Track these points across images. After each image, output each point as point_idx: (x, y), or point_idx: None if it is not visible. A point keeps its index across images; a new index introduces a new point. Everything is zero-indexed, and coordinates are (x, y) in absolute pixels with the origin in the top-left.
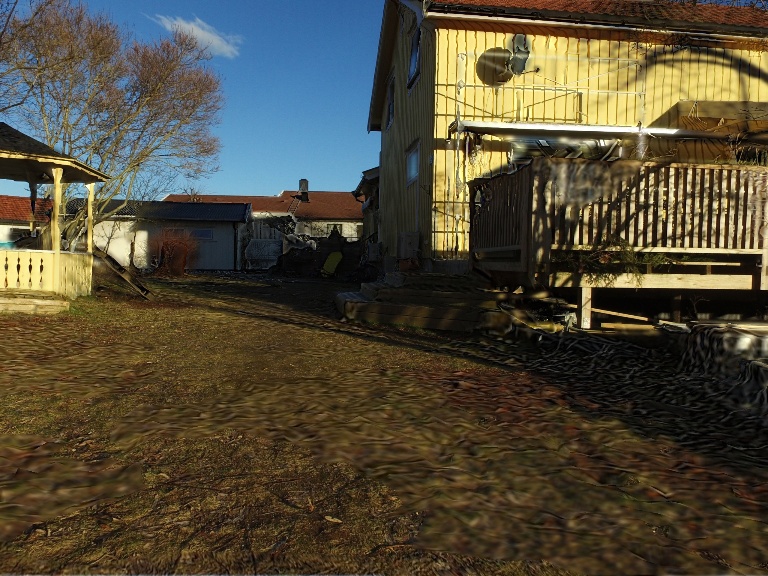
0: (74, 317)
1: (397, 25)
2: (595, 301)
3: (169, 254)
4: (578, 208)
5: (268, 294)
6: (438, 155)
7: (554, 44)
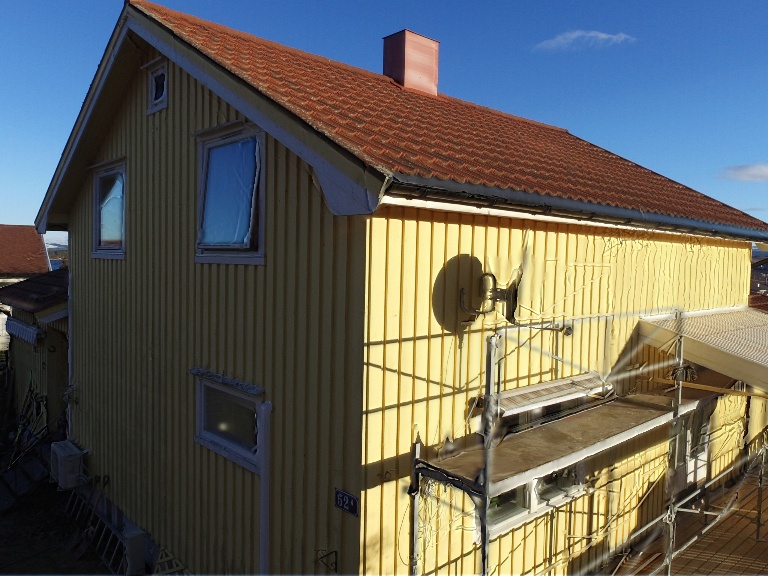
0: None
1: (133, 84)
2: None
3: None
4: None
5: None
6: (369, 501)
7: (533, 244)
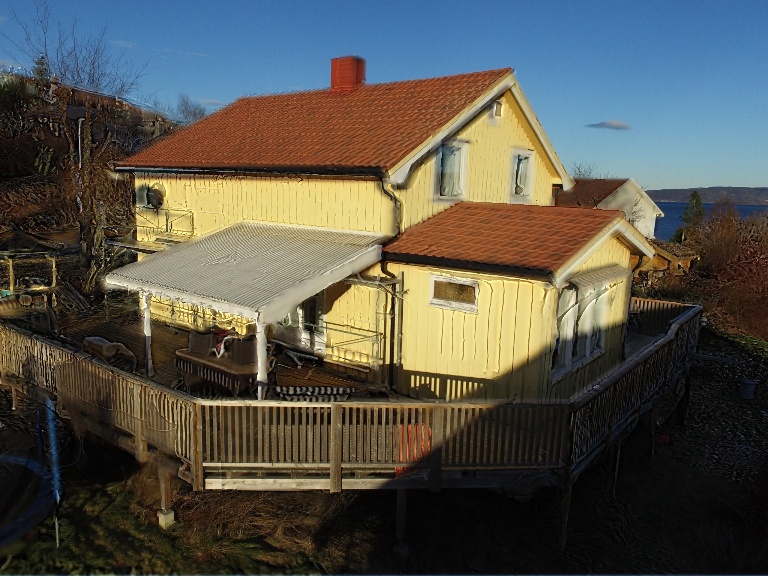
0: None
1: None
2: None
3: None
4: None
5: None
6: None
7: (179, 179)
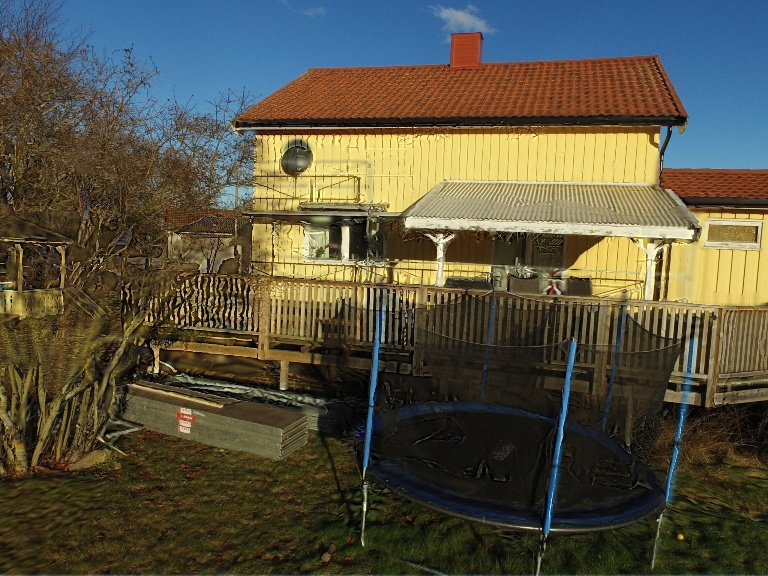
0: None
1: None
2: (161, 357)
3: None
4: (148, 300)
5: None
6: (255, 228)
7: (338, 141)
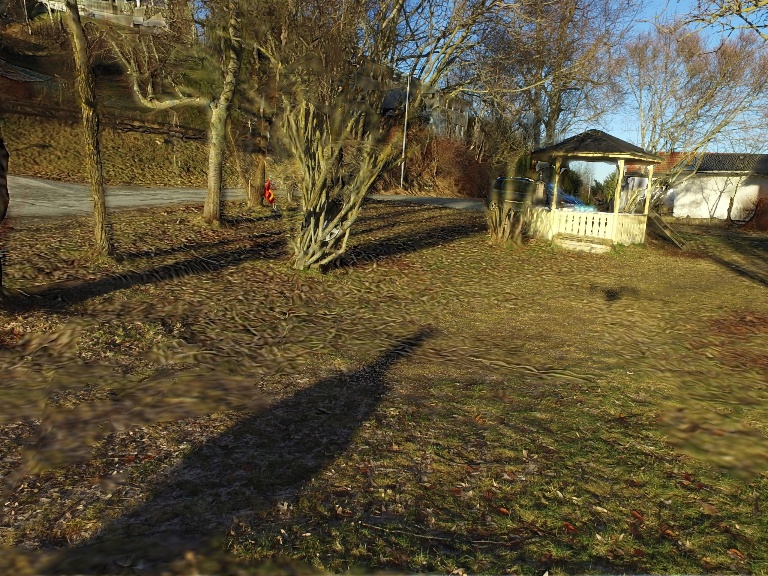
0: (610, 256)
1: None
2: None
3: (759, 210)
4: None
5: None
6: None
7: None
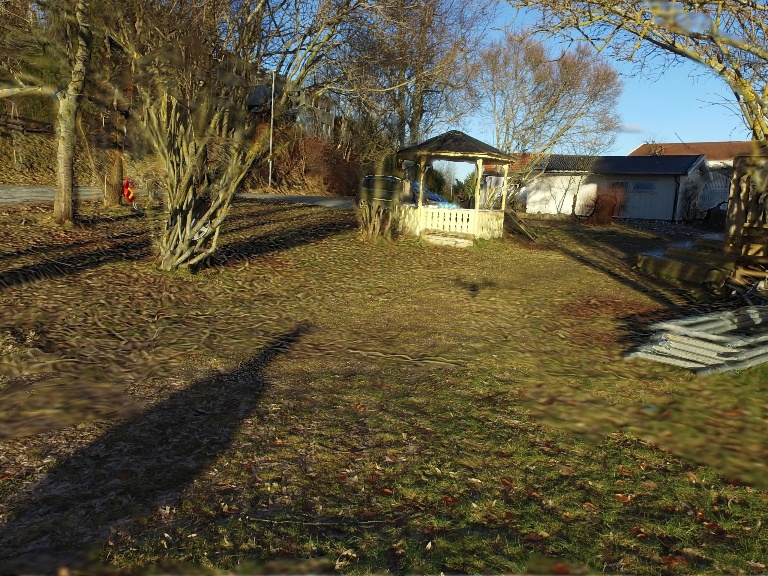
0: (473, 250)
1: None
2: None
3: (598, 206)
4: None
5: (635, 245)
6: None
7: None
